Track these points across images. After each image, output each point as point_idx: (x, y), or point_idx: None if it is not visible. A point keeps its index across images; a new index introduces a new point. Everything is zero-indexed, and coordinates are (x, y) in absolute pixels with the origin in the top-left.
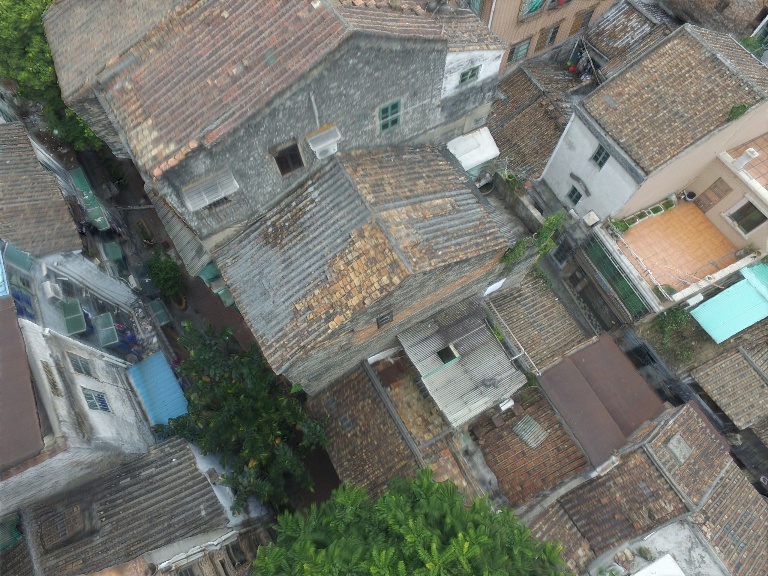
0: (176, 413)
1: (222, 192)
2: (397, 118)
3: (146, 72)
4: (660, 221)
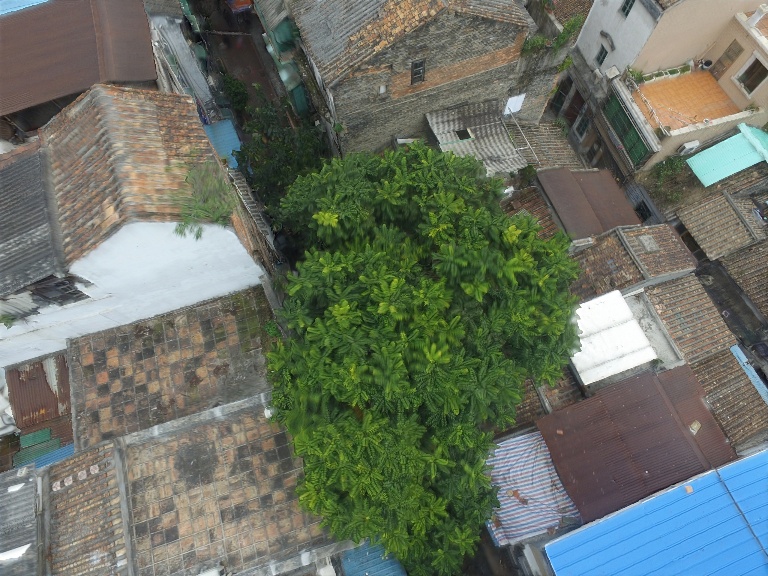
0: (236, 162)
1: None
2: None
3: None
4: (675, 82)
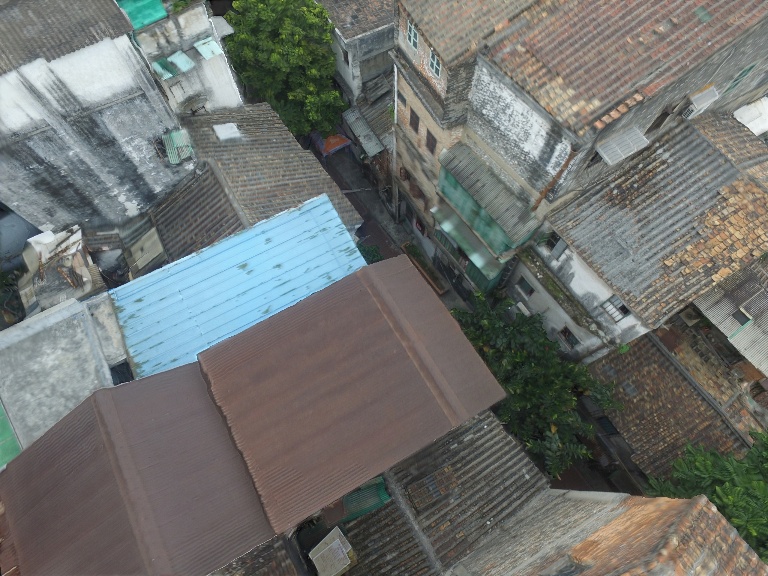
0: None
1: (635, 147)
2: (739, 82)
3: (544, 34)
4: None
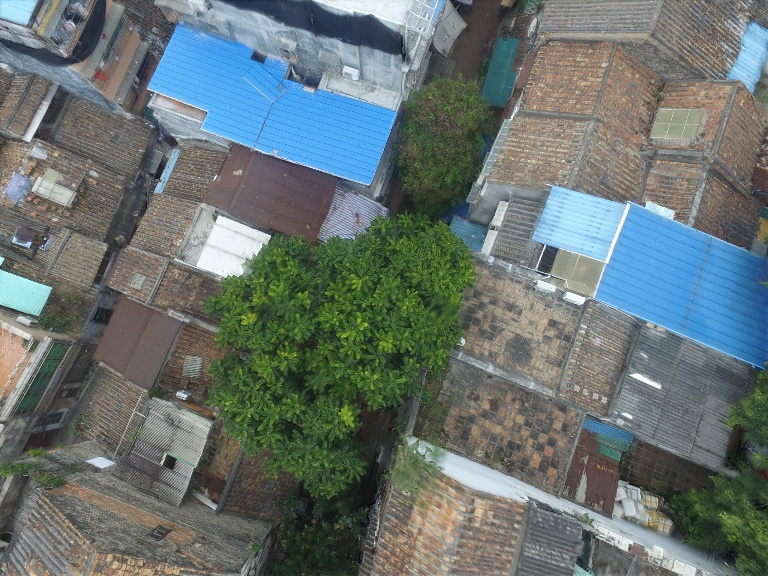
0: None
1: None
2: None
3: None
4: None
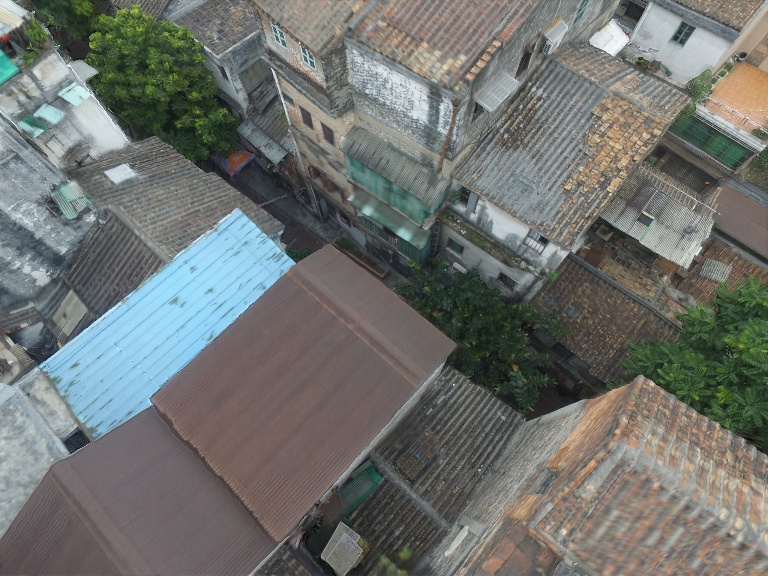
0: None
1: (508, 90)
2: (583, 11)
3: (399, 6)
4: (728, 82)
